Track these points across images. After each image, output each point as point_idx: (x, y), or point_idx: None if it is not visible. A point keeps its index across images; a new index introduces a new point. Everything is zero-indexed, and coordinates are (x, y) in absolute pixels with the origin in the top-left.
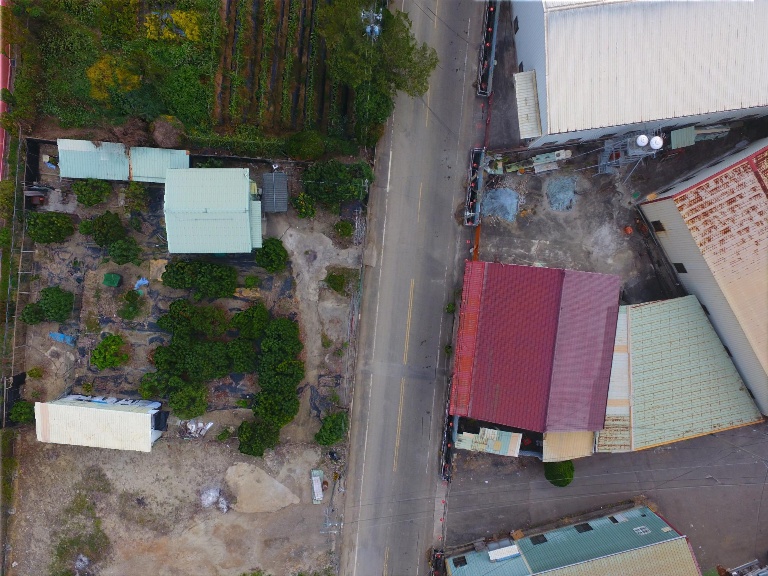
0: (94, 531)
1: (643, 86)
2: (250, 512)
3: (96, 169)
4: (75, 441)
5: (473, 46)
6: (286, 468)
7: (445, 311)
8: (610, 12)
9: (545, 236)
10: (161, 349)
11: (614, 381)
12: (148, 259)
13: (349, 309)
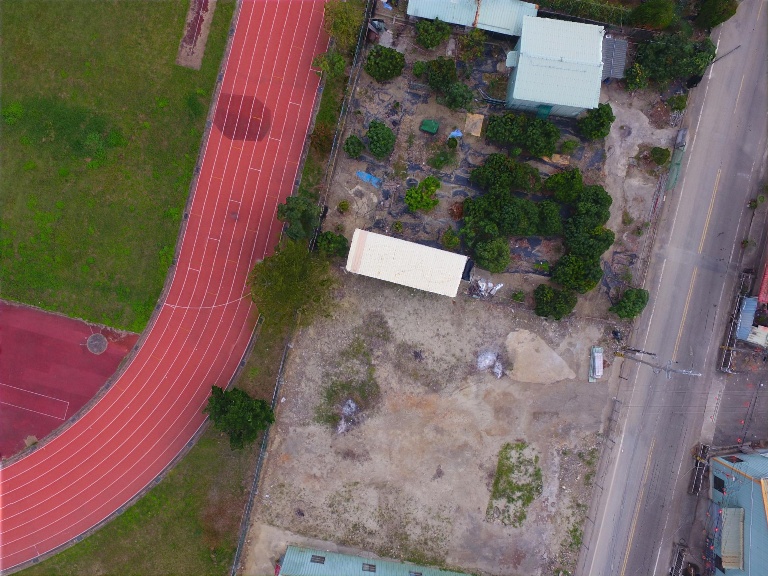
0: (367, 378)
1: None
2: (524, 381)
3: (444, 11)
4: (383, 275)
5: None
6: (567, 341)
7: (746, 206)
8: None
9: None
10: (472, 200)
11: None
12: (465, 112)
13: (655, 189)
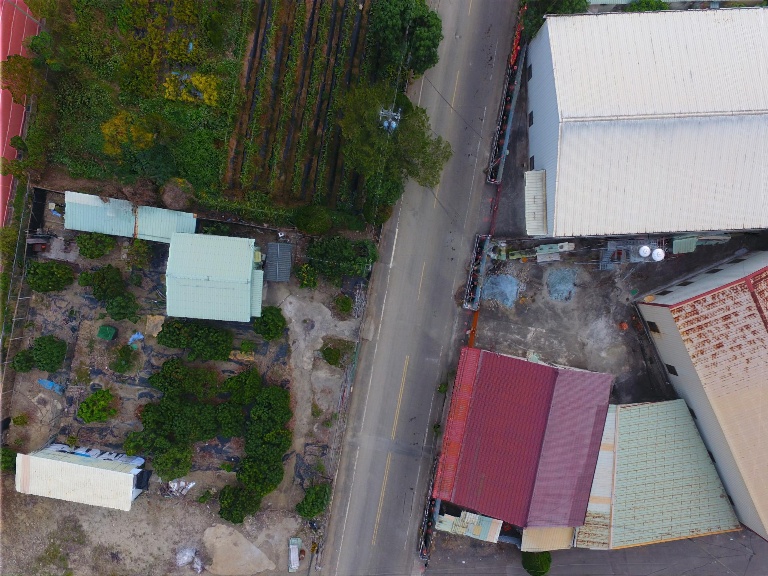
0: None
1: (650, 199)
2: (224, 575)
3: (101, 224)
4: (54, 494)
5: (487, 133)
6: (265, 533)
7: (437, 390)
8: (623, 128)
9: (542, 324)
10: (150, 407)
11: (598, 478)
12: (145, 314)
13: (342, 380)
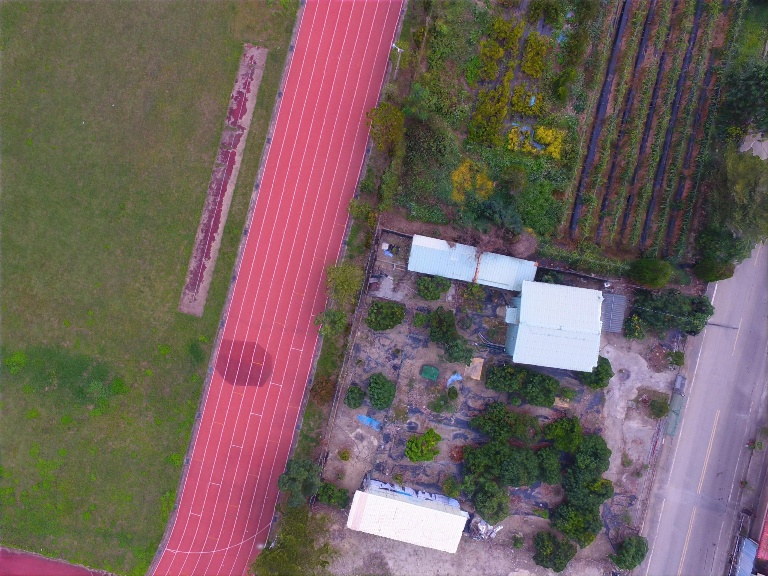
0: None
1: None
2: None
3: (444, 267)
4: (383, 533)
5: None
6: None
7: (745, 446)
8: None
9: None
10: (472, 449)
11: None
12: None
13: (654, 432)
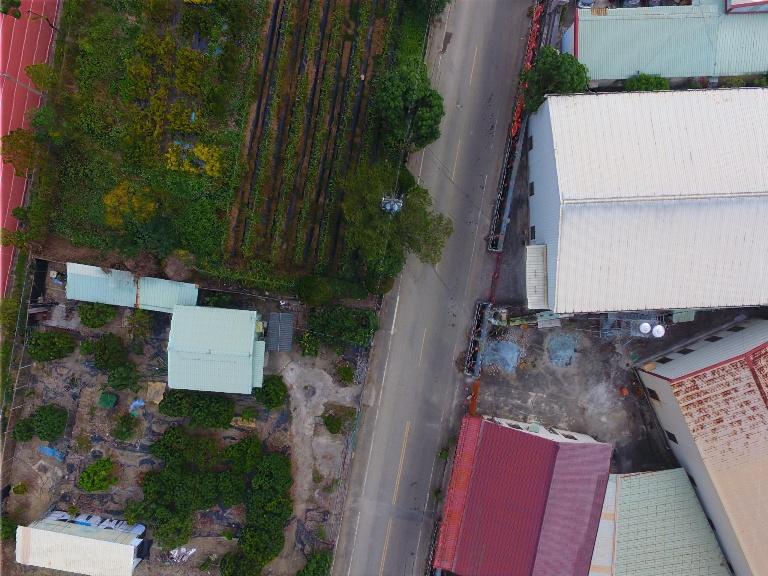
0: None
1: (650, 277)
2: None
3: (103, 294)
4: (54, 565)
5: (488, 201)
6: None
7: (438, 455)
8: (624, 209)
9: (542, 389)
10: (151, 475)
11: (598, 547)
12: (146, 381)
13: (343, 446)
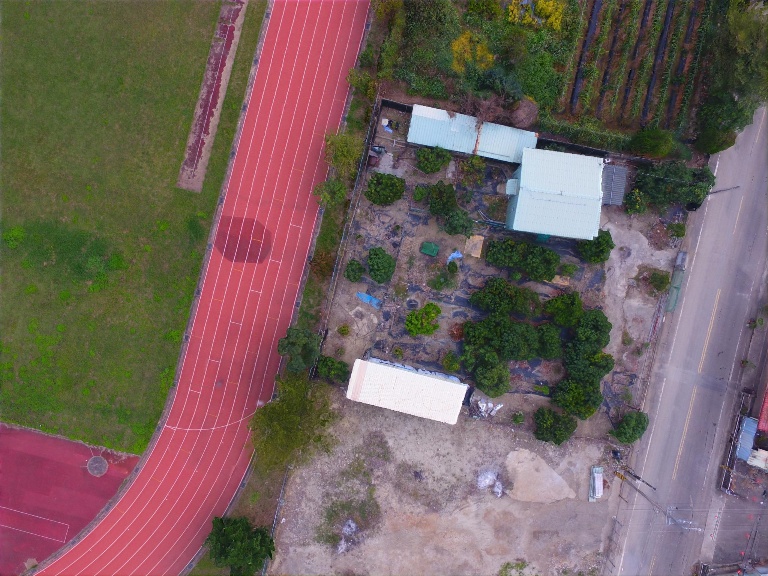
0: (367, 498)
1: None
2: (524, 500)
3: (444, 138)
4: (383, 403)
5: None
6: (567, 461)
7: (746, 325)
8: None
9: None
10: (472, 324)
11: None
12: None
13: (654, 310)
